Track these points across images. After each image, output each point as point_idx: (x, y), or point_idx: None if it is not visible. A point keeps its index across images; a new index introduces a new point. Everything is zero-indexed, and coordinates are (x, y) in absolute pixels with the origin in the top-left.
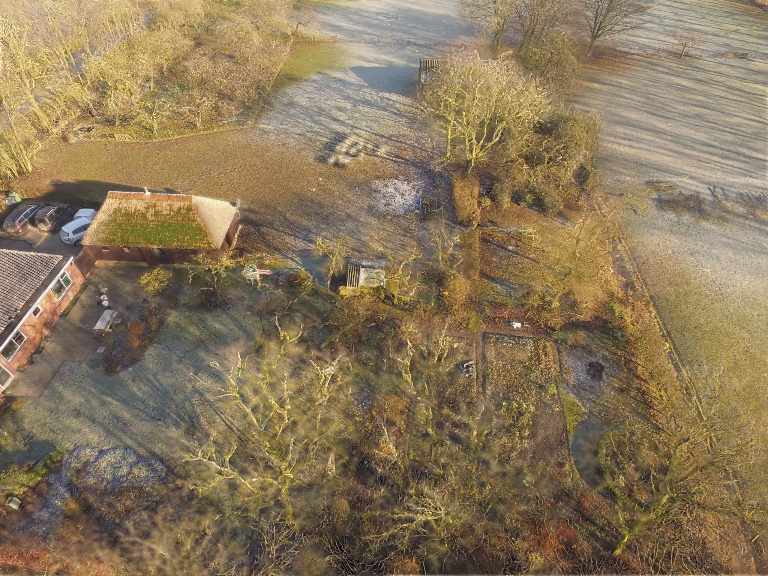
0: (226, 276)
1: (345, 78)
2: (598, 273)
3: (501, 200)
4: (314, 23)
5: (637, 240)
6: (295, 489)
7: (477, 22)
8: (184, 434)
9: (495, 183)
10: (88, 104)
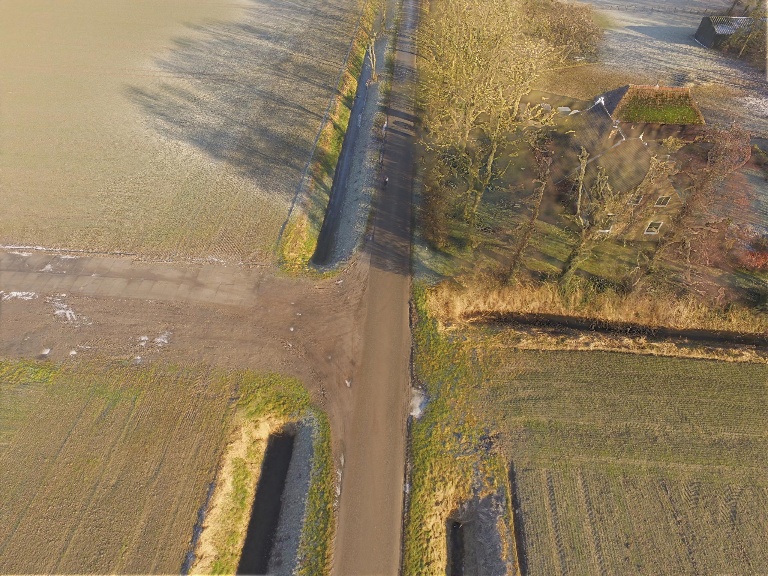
0: (699, 147)
1: (631, 33)
2: None
3: None
4: None
5: None
6: None
7: None
8: None
9: None
10: None
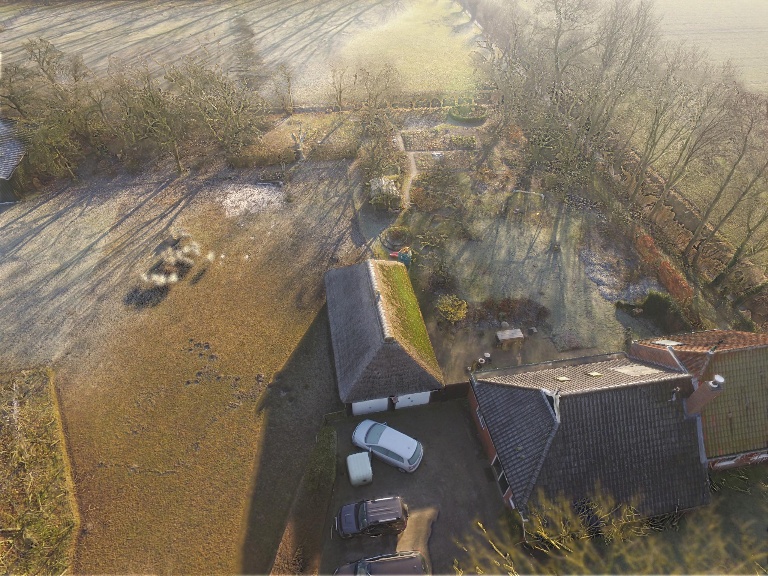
0: None
1: None
2: None
3: None
4: None
5: (295, 100)
6: (550, 203)
7: None
8: None
9: None
10: None
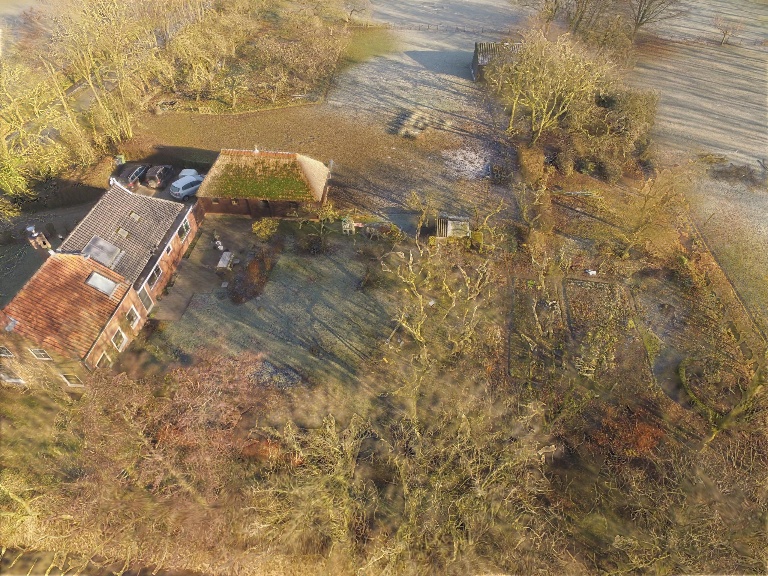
0: (323, 228)
1: (402, 61)
2: (677, 218)
3: (565, 168)
4: (368, 10)
5: (695, 204)
6: None
7: (526, 10)
8: (312, 352)
9: (556, 154)
10: (167, 81)
